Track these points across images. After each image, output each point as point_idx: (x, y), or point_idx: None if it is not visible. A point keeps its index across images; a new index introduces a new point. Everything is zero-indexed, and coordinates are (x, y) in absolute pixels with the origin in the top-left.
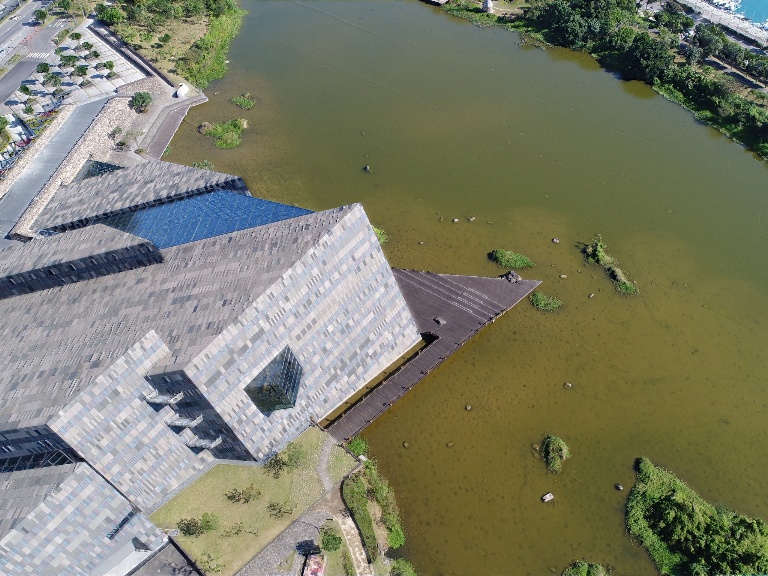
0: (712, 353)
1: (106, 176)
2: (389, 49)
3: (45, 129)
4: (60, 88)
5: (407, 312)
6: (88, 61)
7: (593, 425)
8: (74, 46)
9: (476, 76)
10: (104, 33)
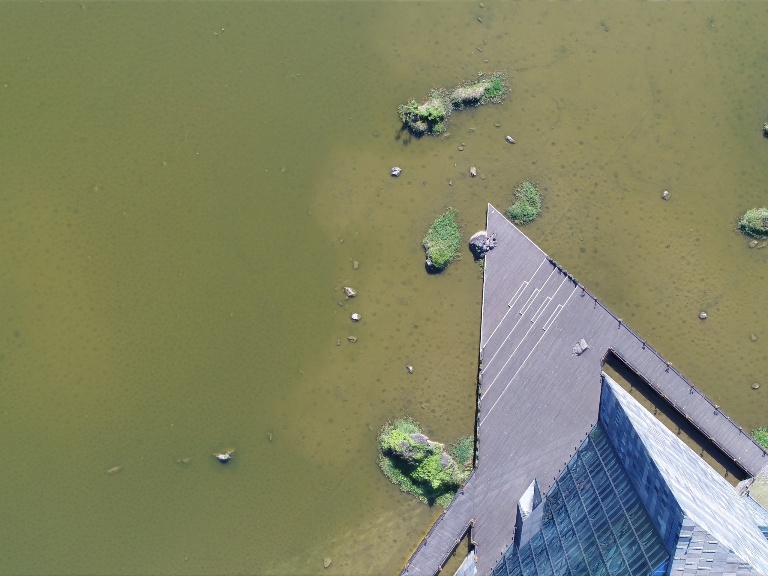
0: (607, 6)
1: None
2: None
3: None
4: None
5: None
6: None
7: (721, 176)
8: None
9: None
10: None
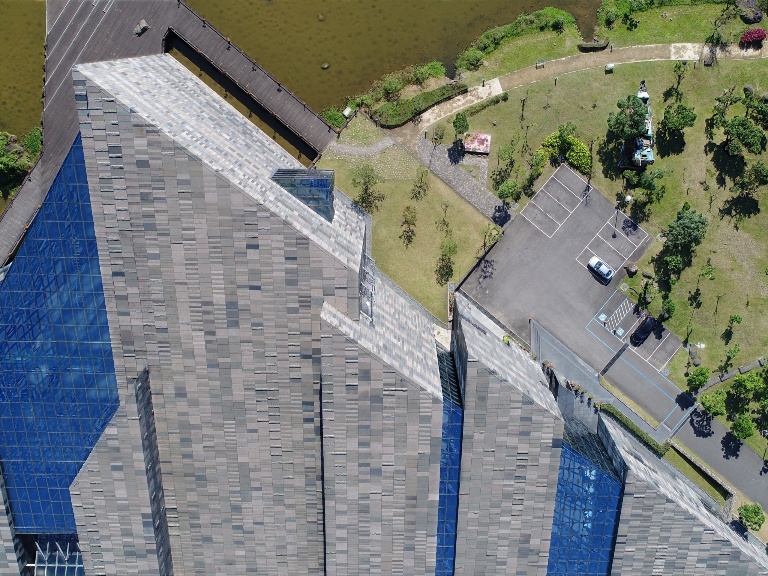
0: None
1: None
2: None
3: None
4: None
5: (154, 59)
6: None
7: None
8: None
9: None
10: None
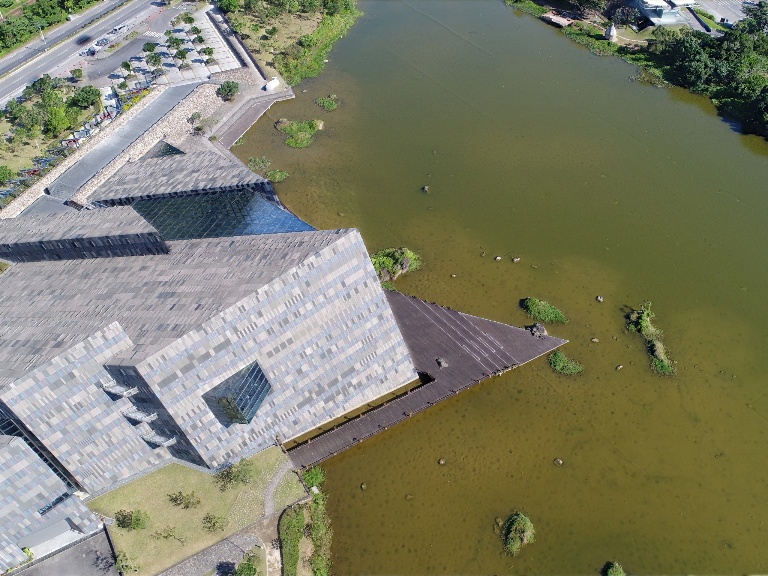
0: (740, 461)
1: (166, 159)
2: (491, 67)
3: (133, 105)
4: (160, 68)
5: (403, 348)
6: (195, 45)
7: (571, 512)
8: (188, 29)
9: (574, 107)
10: (219, 20)
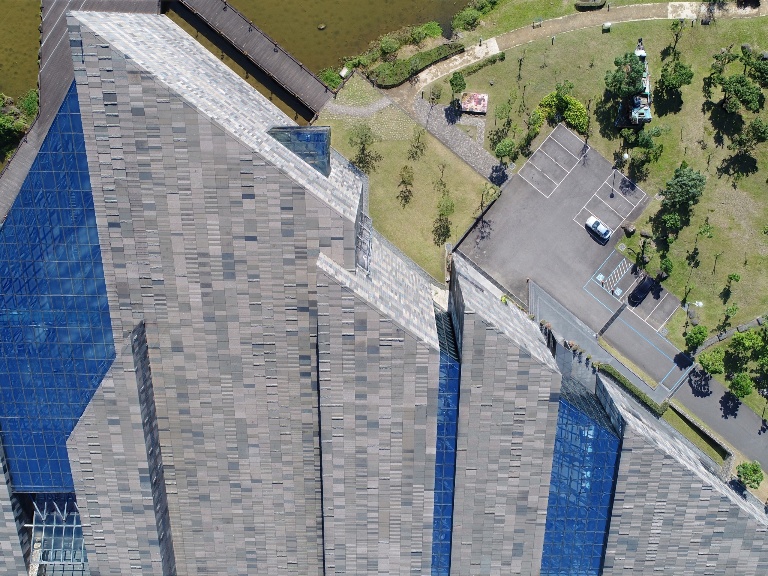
0: None
1: None
2: None
3: None
4: None
5: (150, 17)
6: None
7: None
8: None
9: None
10: None
